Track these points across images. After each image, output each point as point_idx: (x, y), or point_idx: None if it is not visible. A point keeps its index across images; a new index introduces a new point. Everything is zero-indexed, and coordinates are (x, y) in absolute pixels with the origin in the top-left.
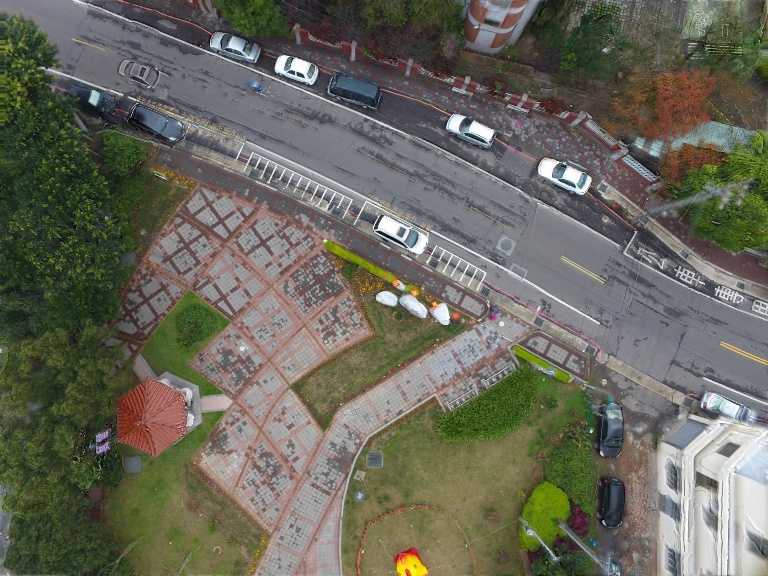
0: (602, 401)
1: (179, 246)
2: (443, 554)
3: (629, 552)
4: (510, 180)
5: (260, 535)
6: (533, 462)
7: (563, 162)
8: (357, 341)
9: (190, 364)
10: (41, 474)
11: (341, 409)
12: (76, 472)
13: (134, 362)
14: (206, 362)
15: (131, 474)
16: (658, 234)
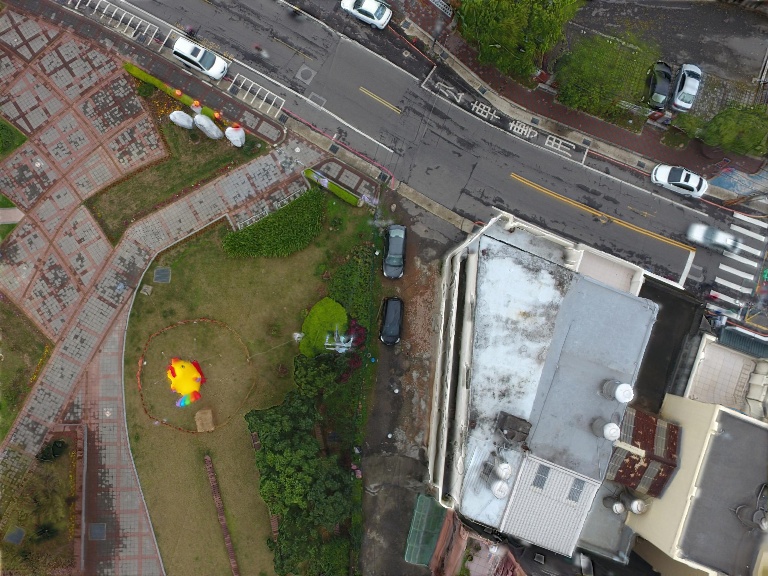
0: None
1: None
2: (224, 368)
3: (409, 371)
4: (315, 14)
5: (44, 345)
6: (318, 281)
7: None
8: (152, 161)
9: None
10: None
11: (132, 226)
12: None
13: None
14: (1, 176)
15: None
16: (458, 70)
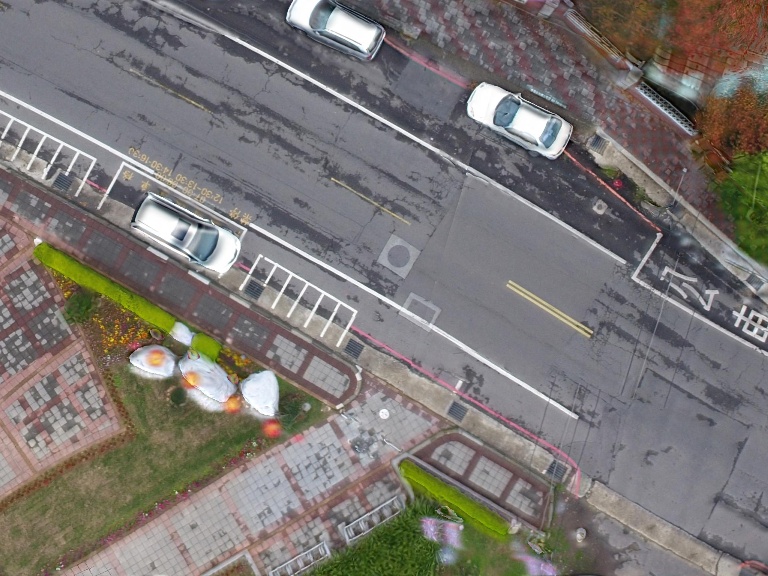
0: (574, 572)
1: None
2: None
3: None
4: (412, 126)
5: None
6: None
7: (515, 93)
8: (94, 443)
9: None
10: None
11: None
12: None
13: None
14: None
15: None
16: (704, 240)
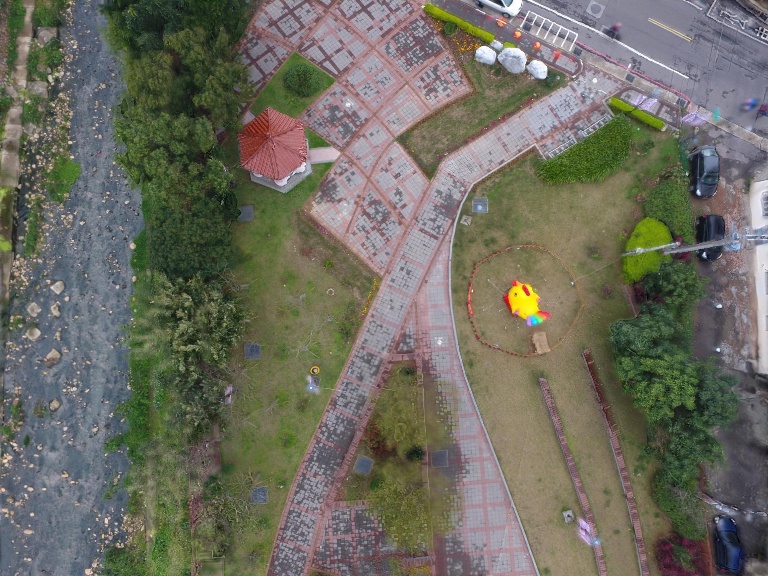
0: (695, 147)
1: (283, 12)
2: (550, 292)
3: (729, 287)
4: None
5: (371, 278)
6: (633, 204)
7: None
8: (458, 97)
9: (298, 119)
10: (183, 163)
11: (445, 159)
12: (213, 168)
13: (244, 118)
14: (313, 117)
15: (244, 222)
16: None
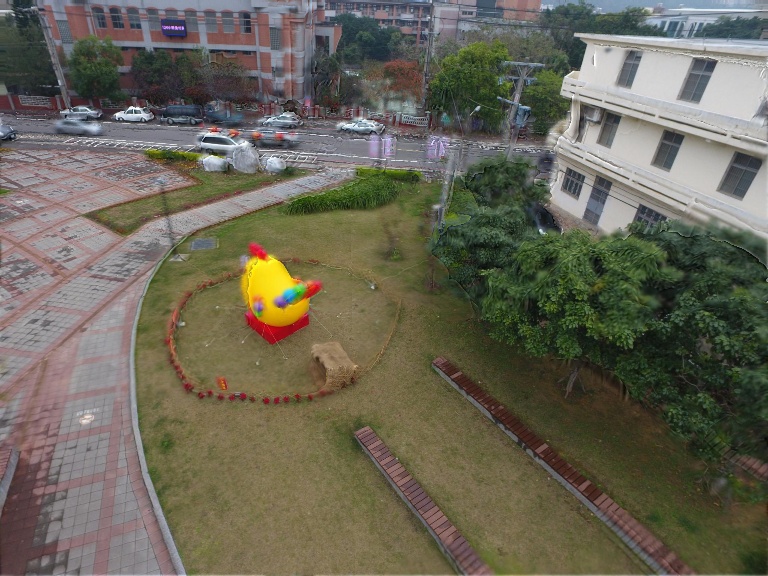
0: None
1: None
2: (337, 302)
3: None
4: None
5: None
6: (424, 218)
7: None
8: (182, 187)
9: None
10: None
11: (156, 221)
12: None
13: None
14: None
15: None
16: None
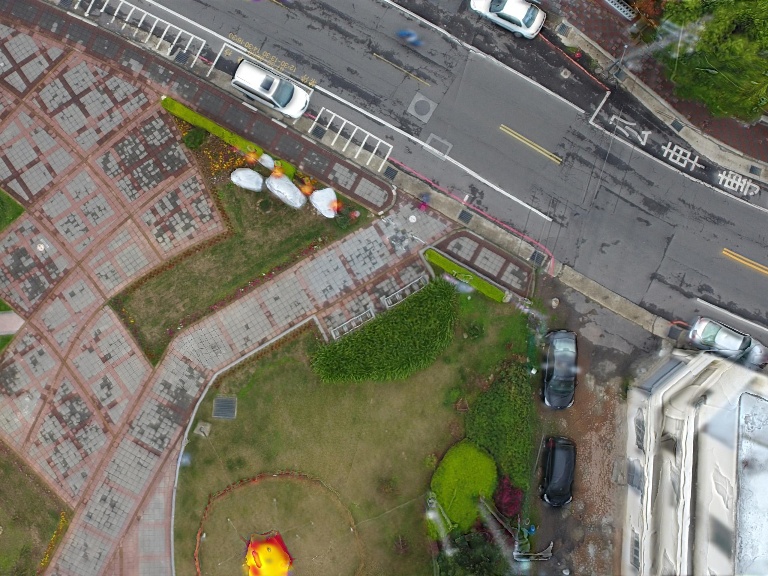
0: (551, 329)
1: None
2: (319, 540)
3: (584, 542)
4: (431, 17)
5: (59, 510)
6: (450, 413)
7: None
8: (205, 239)
9: None
10: None
11: (180, 335)
12: None
13: None
14: None
15: None
16: (641, 97)
